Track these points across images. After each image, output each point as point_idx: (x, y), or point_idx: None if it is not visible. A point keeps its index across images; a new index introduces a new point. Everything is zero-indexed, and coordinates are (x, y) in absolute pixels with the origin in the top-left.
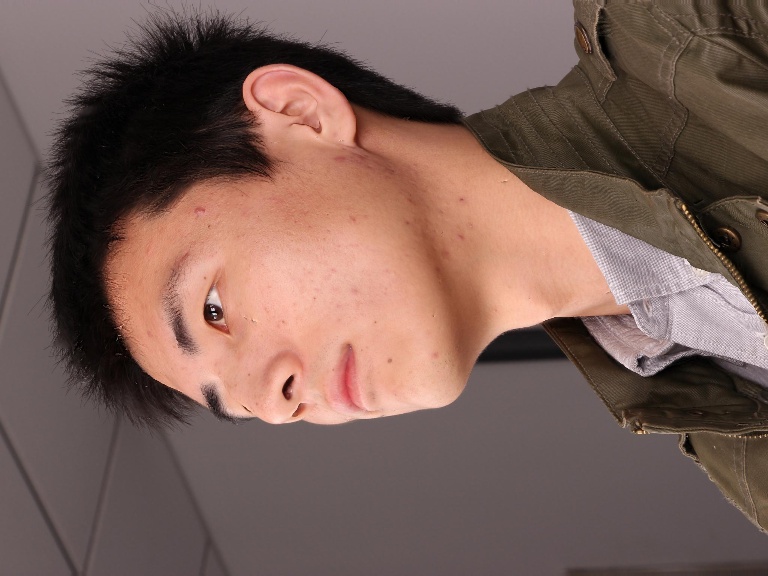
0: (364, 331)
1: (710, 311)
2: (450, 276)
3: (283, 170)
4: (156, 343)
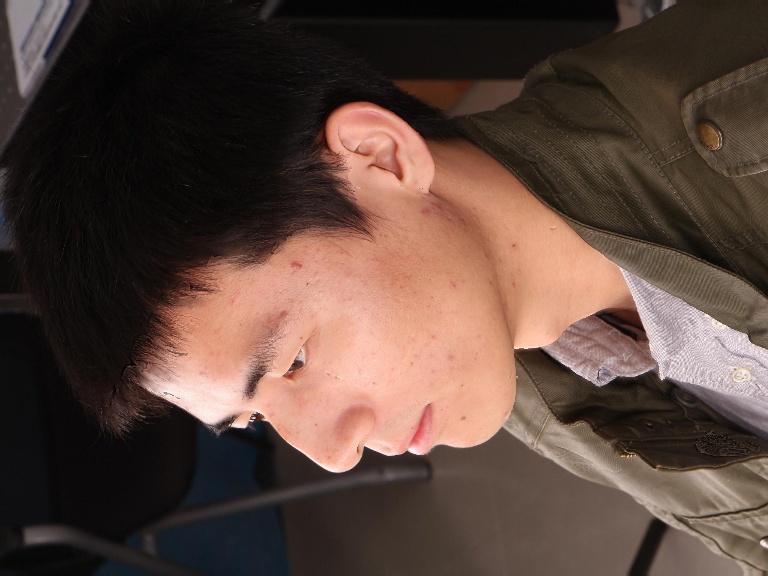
0: (450, 393)
1: (701, 350)
2: (509, 328)
3: (380, 226)
4: (206, 382)
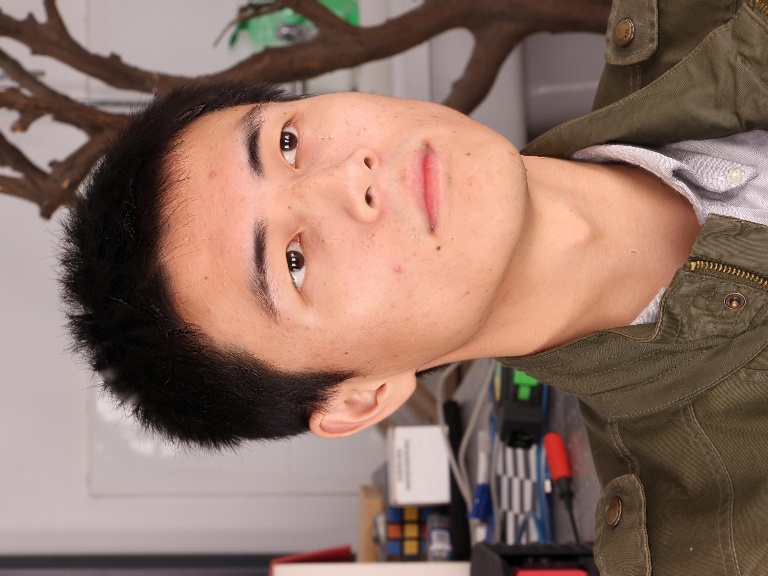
0: (444, 134)
1: None
2: None
3: None
4: (217, 181)
